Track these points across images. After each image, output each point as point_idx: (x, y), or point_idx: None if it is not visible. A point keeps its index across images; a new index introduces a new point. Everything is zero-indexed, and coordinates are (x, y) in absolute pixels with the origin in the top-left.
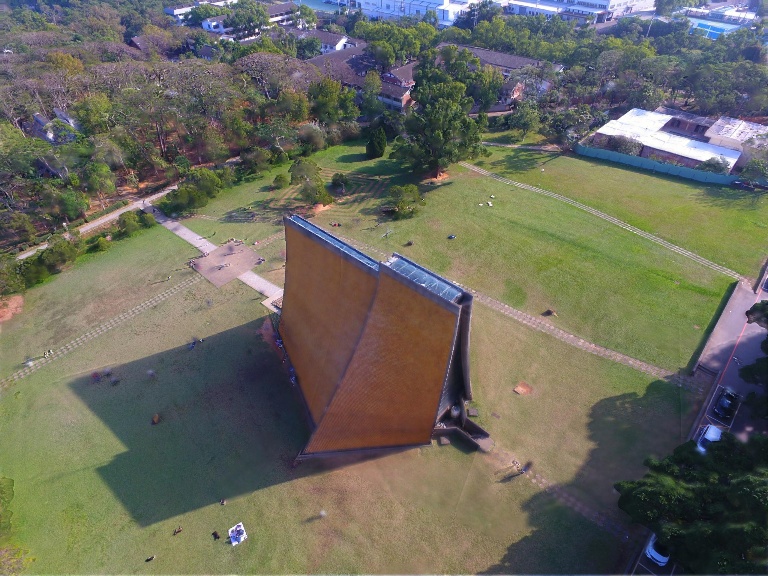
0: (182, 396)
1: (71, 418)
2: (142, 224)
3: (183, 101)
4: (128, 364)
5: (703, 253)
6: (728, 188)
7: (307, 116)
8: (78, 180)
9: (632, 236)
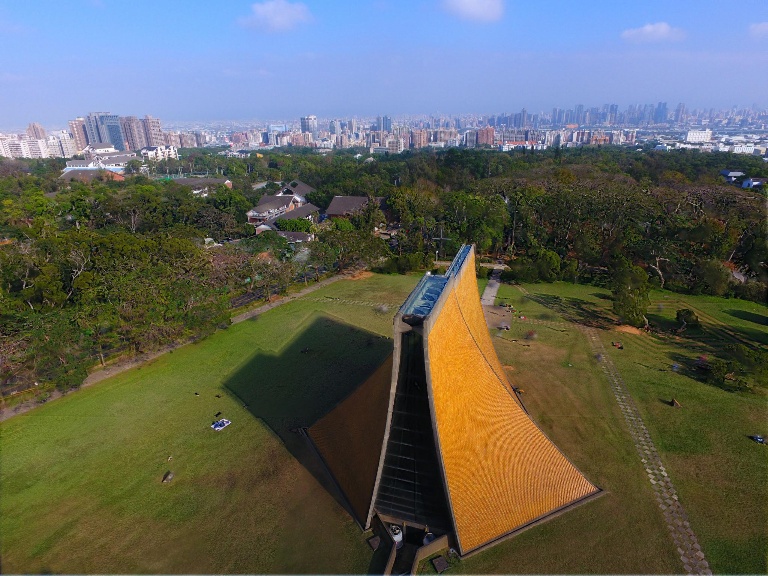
0: (331, 352)
1: (293, 325)
2: (478, 274)
3: (592, 203)
4: (346, 323)
5: None
6: None
7: (727, 255)
8: (466, 229)
9: None
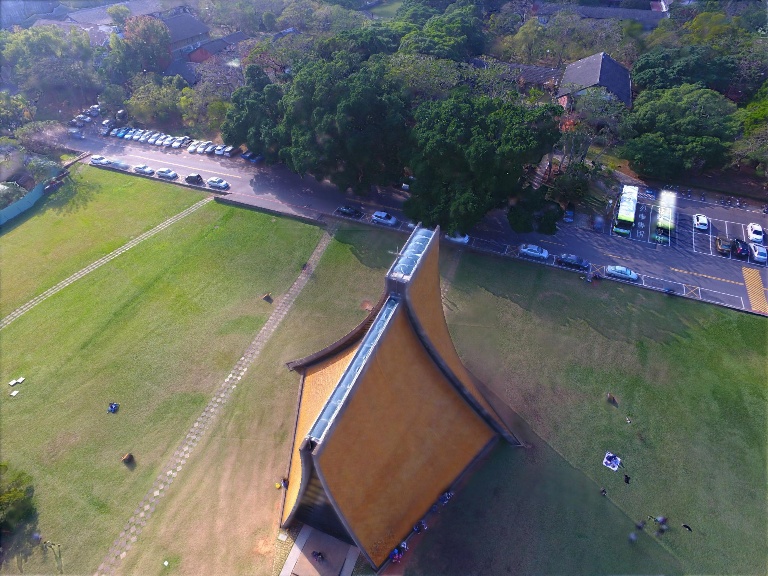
0: None
1: None
2: None
3: None
4: None
5: (170, 214)
6: (52, 195)
7: None
8: None
9: (135, 250)
